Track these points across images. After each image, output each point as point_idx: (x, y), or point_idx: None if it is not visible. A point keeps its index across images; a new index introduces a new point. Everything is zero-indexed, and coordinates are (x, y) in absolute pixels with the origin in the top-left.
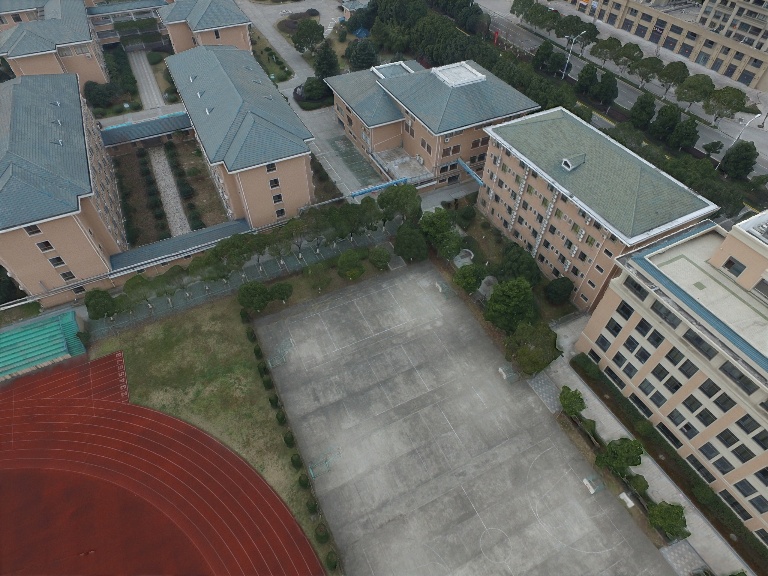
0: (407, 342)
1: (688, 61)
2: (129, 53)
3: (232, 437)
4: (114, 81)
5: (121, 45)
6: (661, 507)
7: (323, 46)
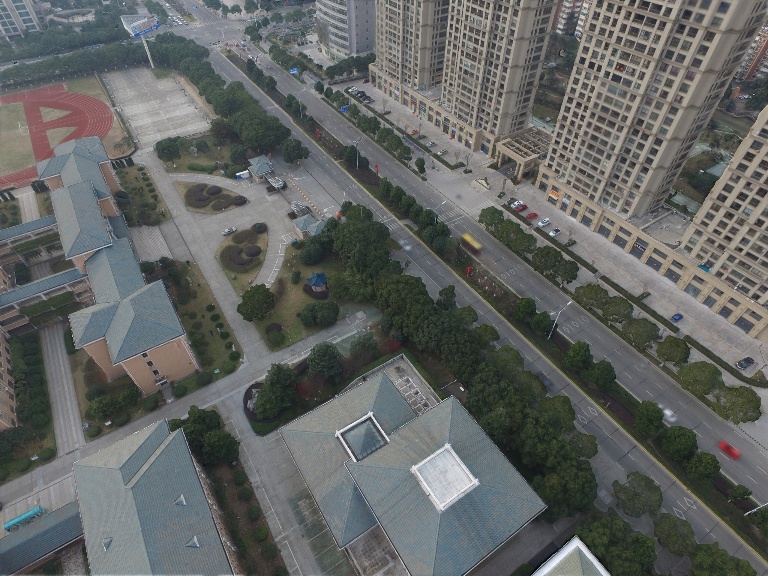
0: None
1: (676, 289)
2: (42, 331)
3: None
4: (21, 400)
5: (31, 324)
6: None
7: (275, 371)
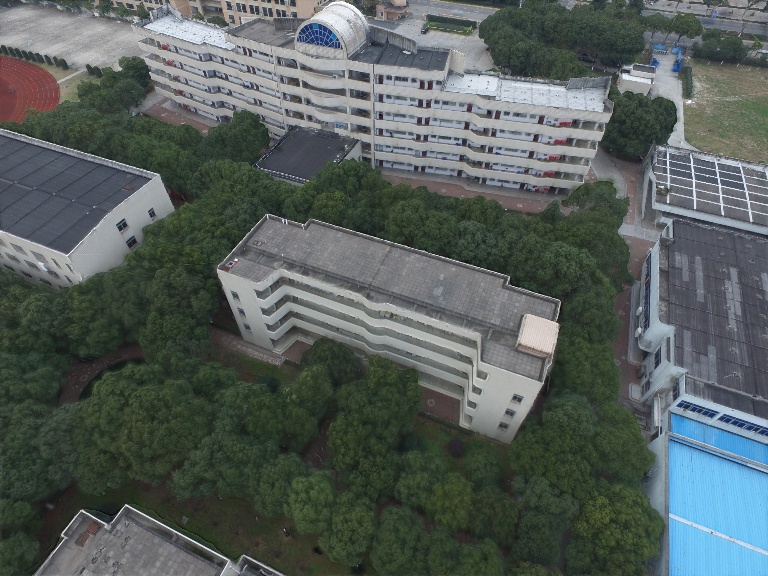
0: None
1: None
2: None
3: None
4: None
5: None
6: None
7: None
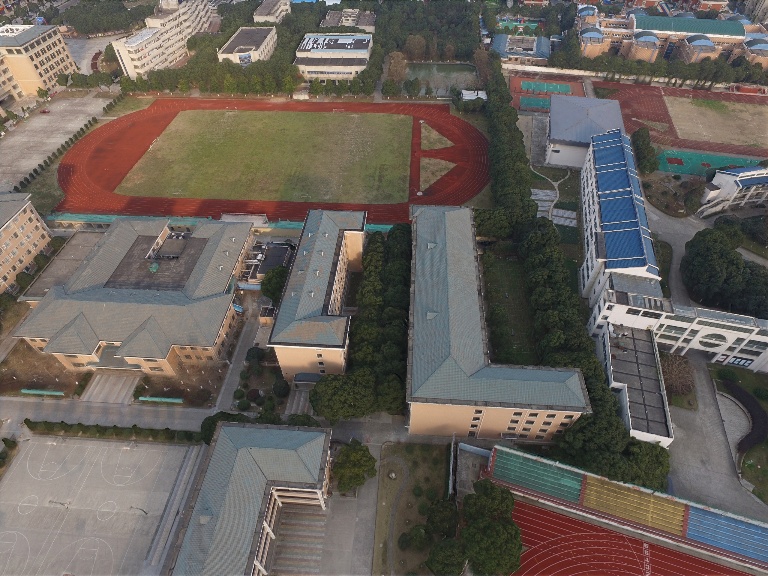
0: None
1: None
2: None
3: (53, 177)
4: None
5: None
6: None
7: None
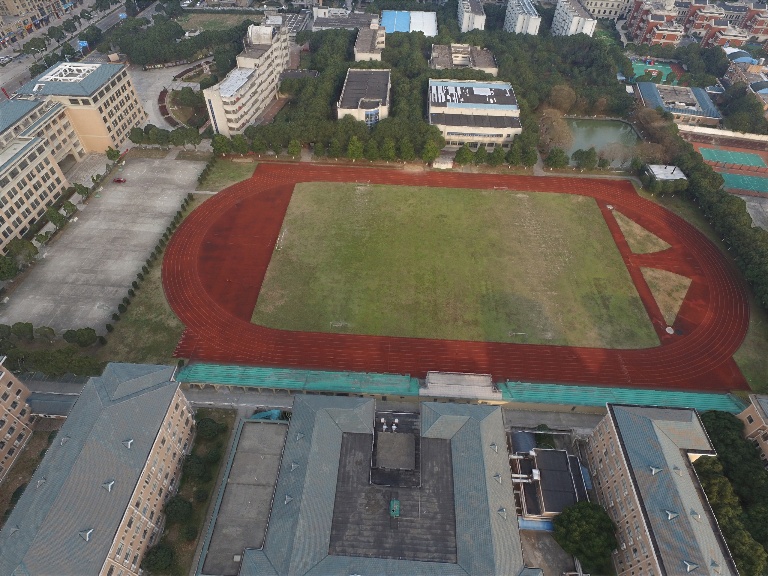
0: (55, 295)
1: None
2: None
3: (159, 293)
4: None
5: None
6: (67, 207)
7: None
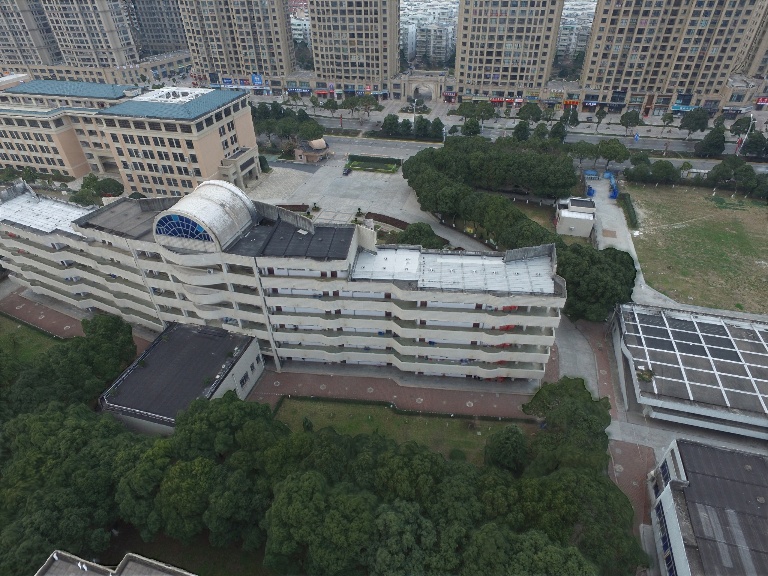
0: None
1: None
2: None
3: None
4: None
5: None
6: None
7: None
